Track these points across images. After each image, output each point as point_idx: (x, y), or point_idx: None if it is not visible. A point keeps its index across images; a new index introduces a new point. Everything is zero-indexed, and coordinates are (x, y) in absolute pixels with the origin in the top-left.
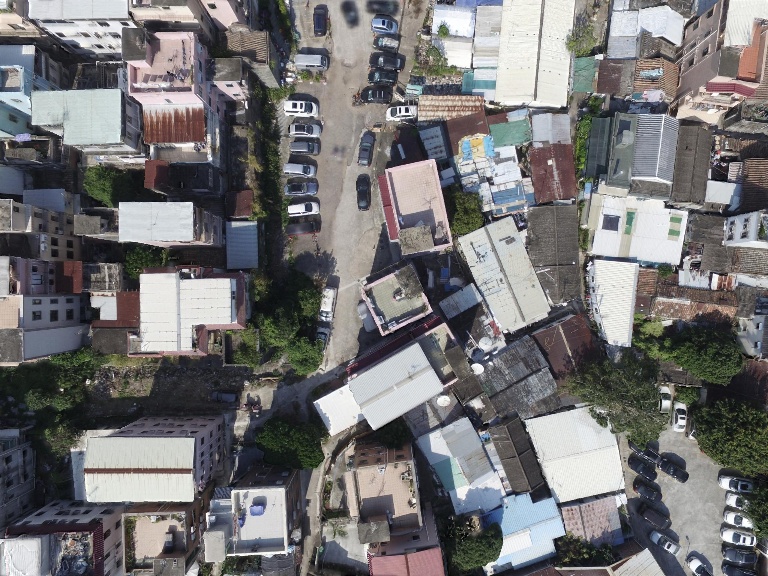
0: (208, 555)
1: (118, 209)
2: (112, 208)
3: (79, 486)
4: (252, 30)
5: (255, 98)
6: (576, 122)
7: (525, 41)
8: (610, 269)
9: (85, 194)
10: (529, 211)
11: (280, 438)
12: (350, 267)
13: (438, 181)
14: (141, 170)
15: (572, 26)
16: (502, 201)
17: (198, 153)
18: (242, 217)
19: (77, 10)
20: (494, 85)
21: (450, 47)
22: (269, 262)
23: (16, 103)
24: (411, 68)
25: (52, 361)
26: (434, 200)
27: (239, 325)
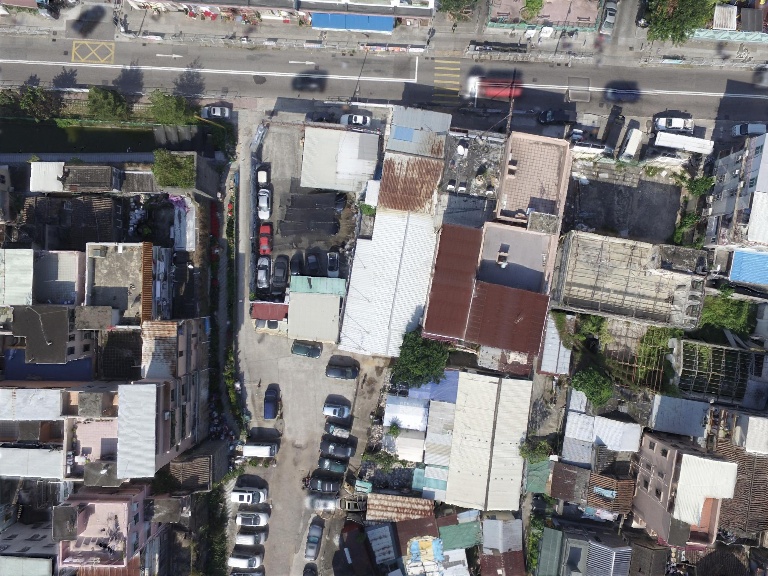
0: None
1: None
2: None
3: None
4: (194, 459)
5: (200, 501)
6: (530, 512)
7: (477, 446)
8: None
9: None
10: None
11: None
12: None
13: None
14: None
15: (526, 428)
16: None
17: None
18: None
19: (12, 469)
20: (445, 486)
21: (401, 444)
22: None
23: None
24: (363, 451)
25: None
26: None
27: None
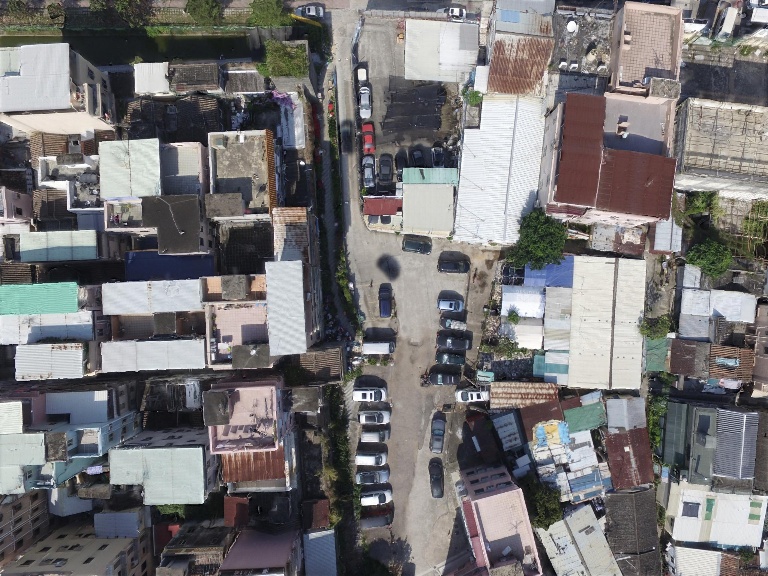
0: None
1: None
2: None
3: None
4: (326, 349)
5: (326, 399)
6: (647, 393)
7: (597, 327)
8: (692, 557)
9: None
10: (607, 497)
11: None
12: (425, 554)
13: (526, 511)
14: None
15: (643, 307)
16: (579, 488)
17: None
18: (319, 527)
19: (152, 362)
20: (567, 369)
21: (520, 332)
22: (342, 550)
23: None
24: (479, 344)
25: None
26: (520, 524)
27: None
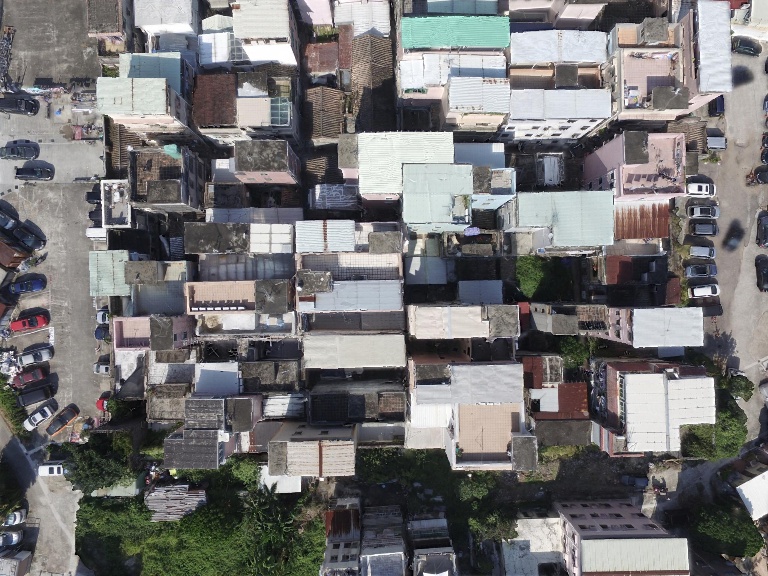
0: None
1: (632, 316)
2: (581, 305)
3: (511, 575)
4: None
5: None
6: None
7: None
8: None
9: (505, 282)
10: None
11: (727, 528)
12: (750, 348)
13: None
14: None
15: None
16: None
17: (644, 245)
18: (669, 305)
19: (560, 110)
20: None
21: None
22: None
23: (484, 201)
24: None
25: None
26: None
27: None
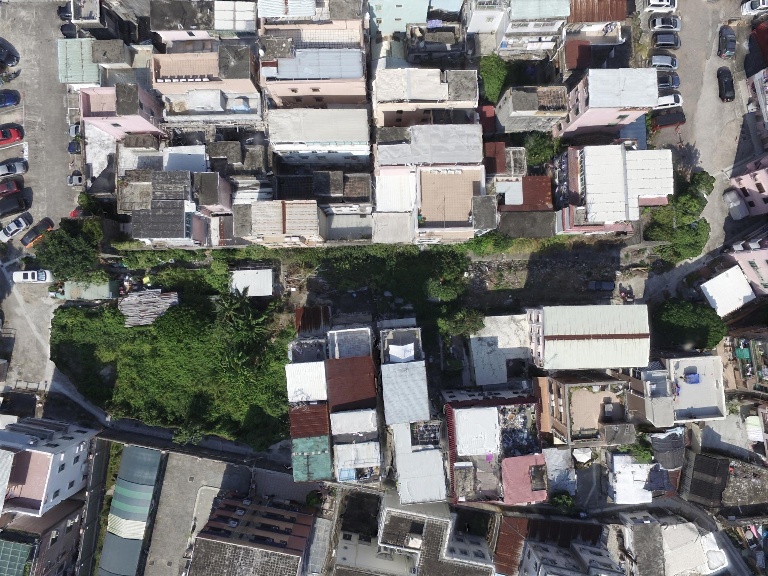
0: (658, 420)
1: (588, 76)
2: (541, 87)
3: (480, 371)
4: None
5: None
6: None
7: None
8: None
9: None
10: None
11: (690, 315)
12: (713, 158)
13: None
14: (522, 62)
15: None
16: None
17: (604, 37)
18: None
19: None
20: None
21: None
22: None
23: None
24: None
25: (467, 244)
26: None
27: (666, 199)
